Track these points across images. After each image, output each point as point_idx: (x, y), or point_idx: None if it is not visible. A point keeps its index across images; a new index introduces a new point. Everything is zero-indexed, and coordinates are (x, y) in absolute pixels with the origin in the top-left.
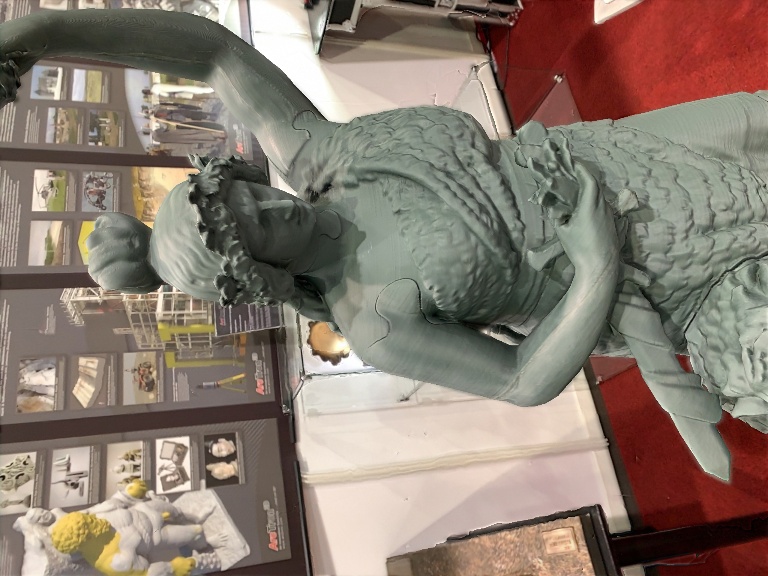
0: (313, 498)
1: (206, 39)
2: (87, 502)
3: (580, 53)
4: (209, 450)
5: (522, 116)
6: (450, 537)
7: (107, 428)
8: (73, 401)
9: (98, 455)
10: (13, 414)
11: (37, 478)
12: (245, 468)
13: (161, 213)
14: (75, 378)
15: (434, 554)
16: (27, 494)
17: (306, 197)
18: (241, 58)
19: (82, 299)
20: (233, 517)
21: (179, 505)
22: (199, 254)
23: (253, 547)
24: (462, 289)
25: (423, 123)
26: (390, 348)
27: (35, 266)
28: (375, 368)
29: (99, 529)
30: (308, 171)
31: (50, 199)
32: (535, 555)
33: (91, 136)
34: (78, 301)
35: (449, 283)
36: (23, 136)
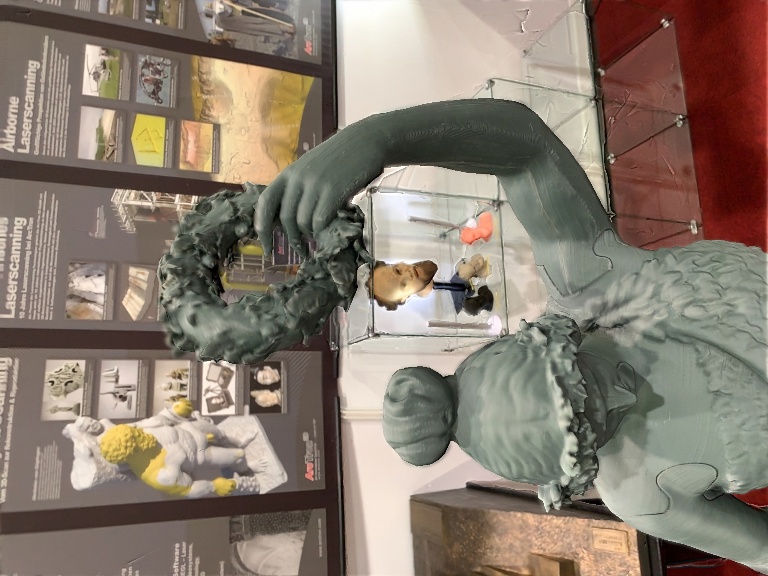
0: (349, 433)
1: (529, 143)
2: (135, 416)
3: (699, 0)
4: (254, 376)
5: (609, 53)
6: (470, 482)
7: (156, 344)
8: (122, 312)
9: (146, 370)
10: (62, 319)
11: (86, 387)
12: (288, 398)
13: (498, 403)
14: (125, 288)
15: (470, 514)
16: (76, 402)
17: (582, 325)
18: (557, 165)
19: (134, 203)
20: (274, 445)
21: (223, 428)
22: (543, 465)
23: (291, 475)
24: (764, 485)
25: (760, 288)
26: (663, 523)
27: (85, 159)
28: (421, 311)
29: (146, 443)
30: (599, 304)
31: (102, 83)
32: (580, 545)
33: (148, 11)
34: (130, 205)
35: (757, 481)
36: (73, 1)
